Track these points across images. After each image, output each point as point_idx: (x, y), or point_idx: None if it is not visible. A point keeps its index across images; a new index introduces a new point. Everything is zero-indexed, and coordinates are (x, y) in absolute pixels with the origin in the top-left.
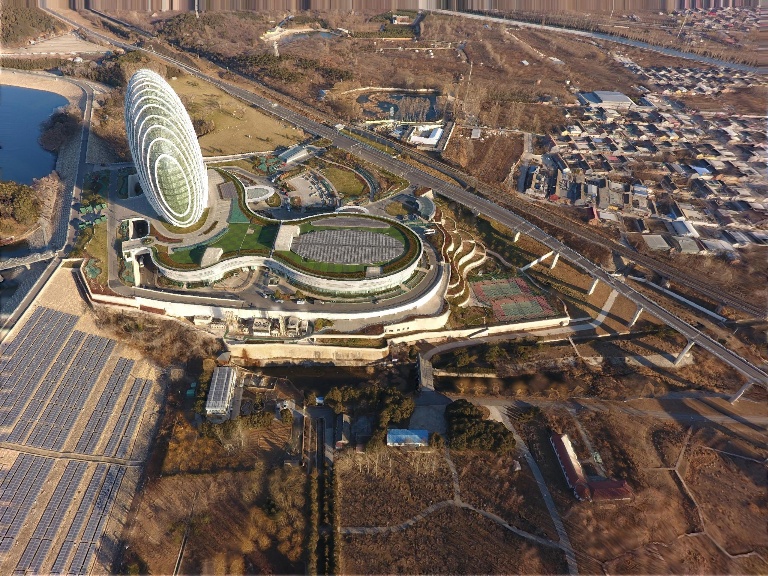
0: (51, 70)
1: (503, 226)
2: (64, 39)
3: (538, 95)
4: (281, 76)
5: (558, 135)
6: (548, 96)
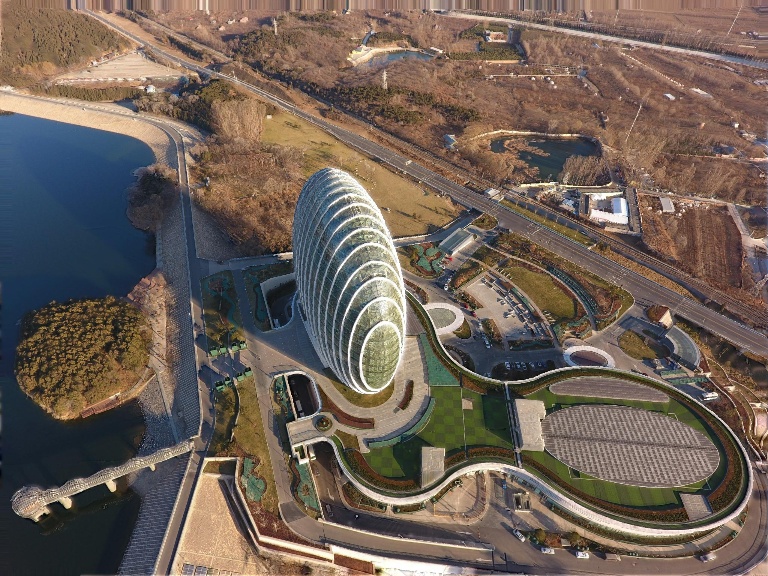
0: (121, 101)
1: None
2: (129, 59)
3: (711, 144)
4: (397, 116)
5: None
6: (725, 146)
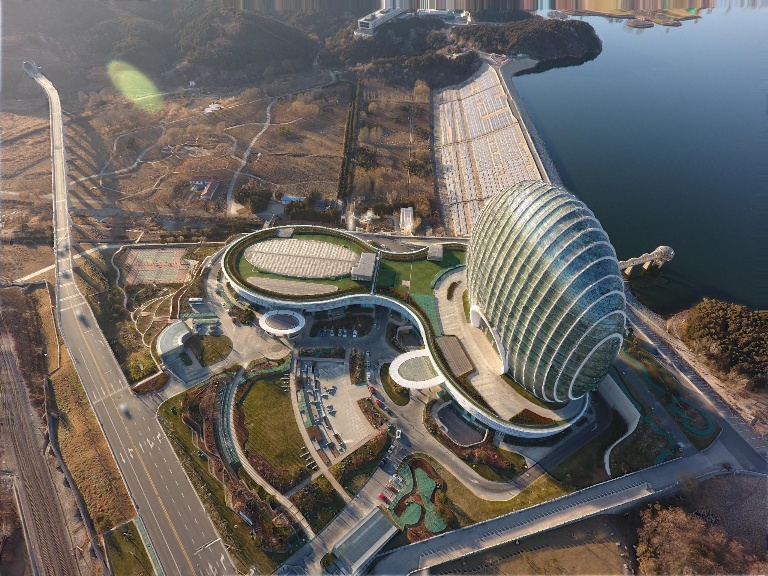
0: None
1: None
2: None
3: None
4: None
5: None
6: None
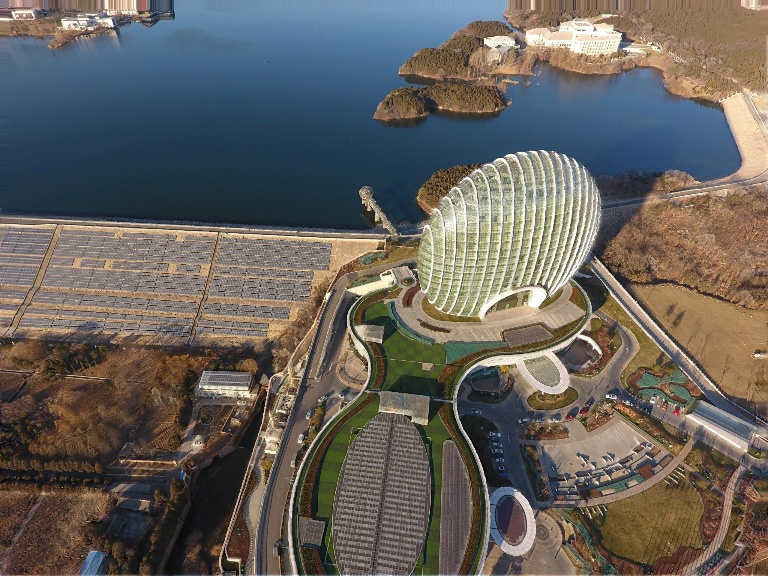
0: None
1: None
2: None
3: None
4: None
5: None
6: None
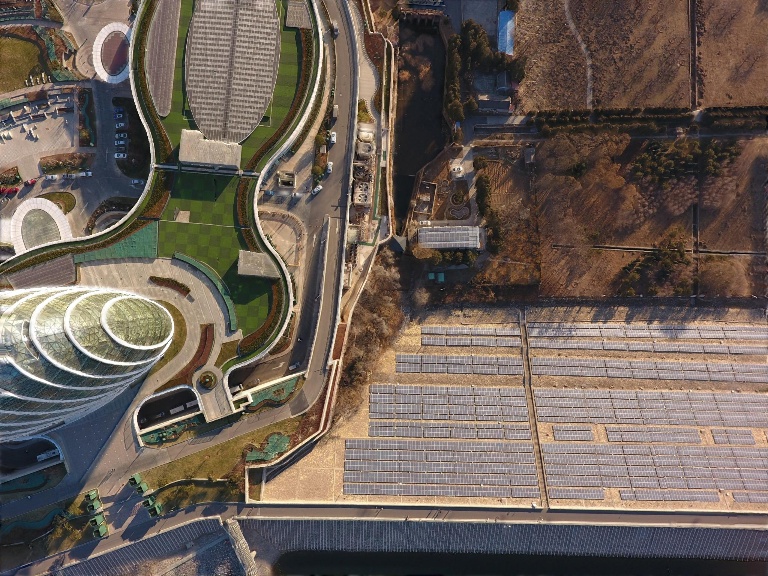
0: None
1: None
2: None
3: None
4: None
5: None
6: None
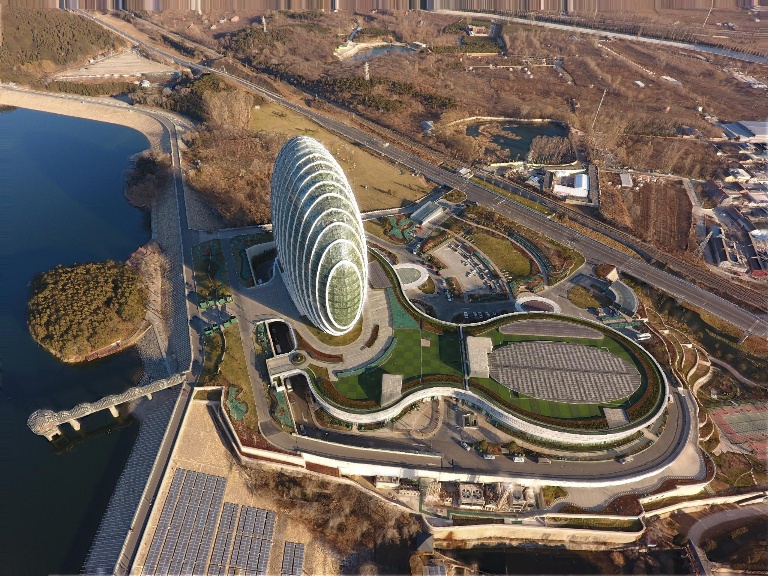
0: (117, 96)
1: (716, 319)
2: (125, 57)
3: (674, 126)
4: (377, 104)
5: (722, 181)
6: (687, 128)
